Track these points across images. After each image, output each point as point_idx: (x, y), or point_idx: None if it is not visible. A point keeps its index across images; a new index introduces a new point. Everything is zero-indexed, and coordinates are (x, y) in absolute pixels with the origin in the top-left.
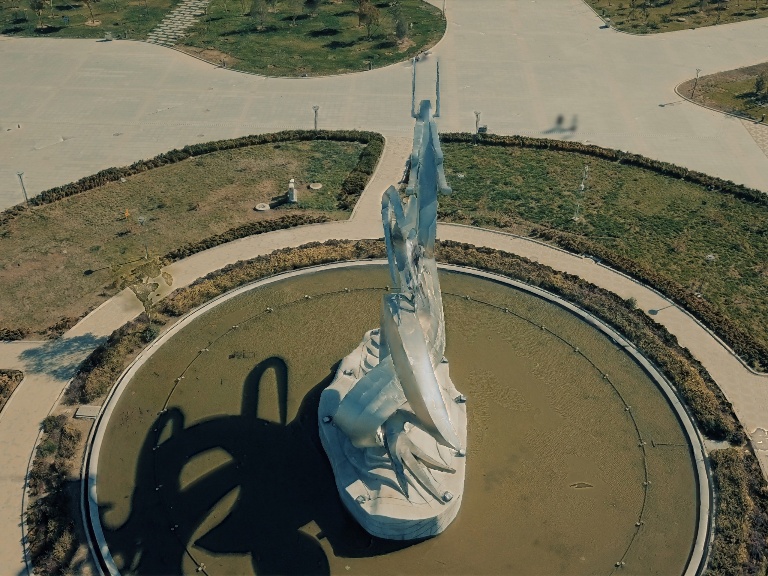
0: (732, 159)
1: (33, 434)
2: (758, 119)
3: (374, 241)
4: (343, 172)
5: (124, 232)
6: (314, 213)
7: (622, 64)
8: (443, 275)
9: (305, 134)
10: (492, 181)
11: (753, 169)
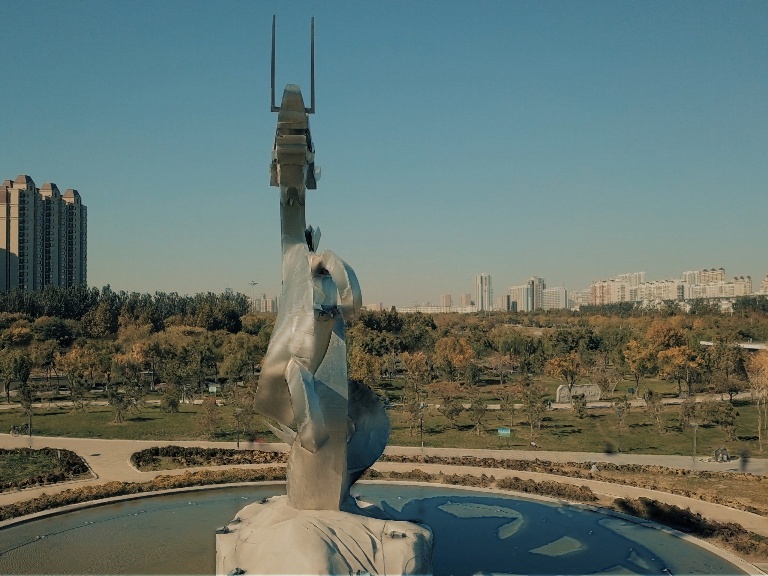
0: None
1: None
2: None
3: None
4: None
5: None
6: None
7: None
8: None
9: None
10: None
11: None
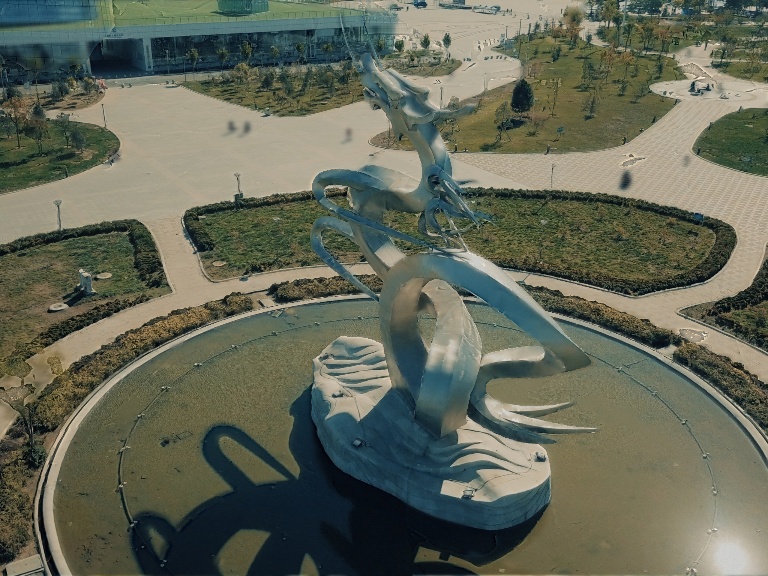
0: (463, 176)
1: None
2: (452, 150)
3: (219, 302)
4: (124, 258)
5: None
6: (127, 297)
7: (309, 136)
8: (318, 308)
9: (48, 236)
10: (285, 231)
11: (485, 179)
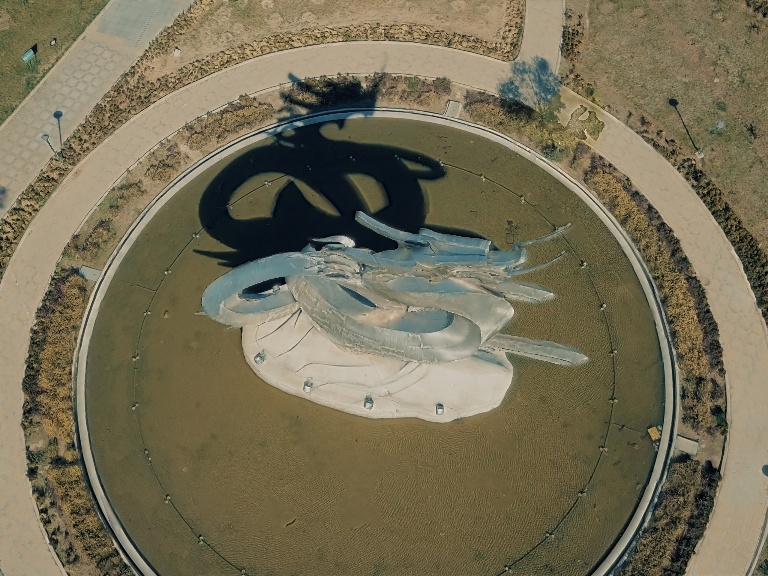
0: None
1: (434, 74)
2: None
3: (724, 407)
4: None
5: (755, 132)
6: None
7: None
8: (636, 476)
9: None
10: None
11: None
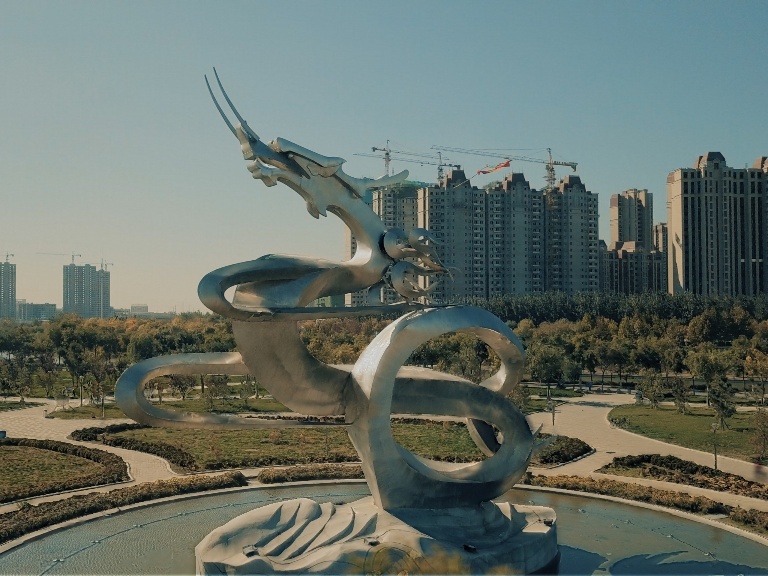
0: None
1: None
2: None
3: None
4: None
5: None
6: None
7: None
8: None
9: None
10: None
11: None
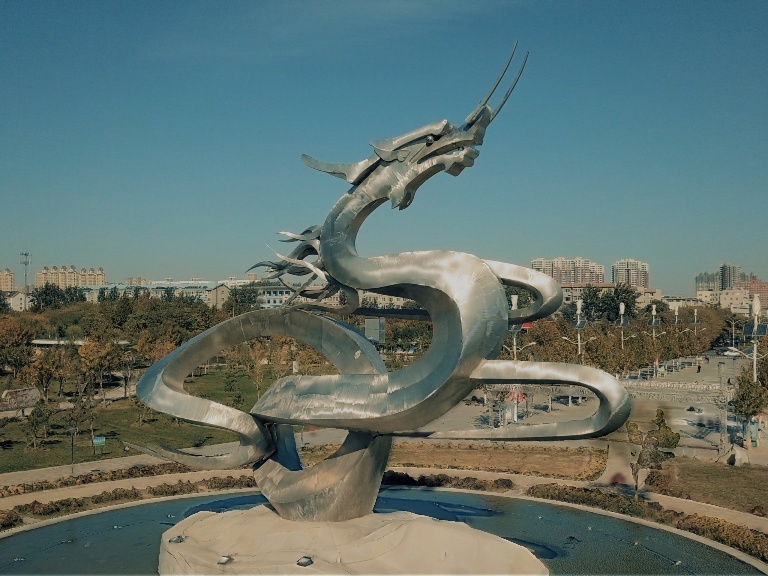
0: None
1: None
2: None
3: None
4: None
5: None
6: None
7: None
8: None
9: None
10: None
11: None
